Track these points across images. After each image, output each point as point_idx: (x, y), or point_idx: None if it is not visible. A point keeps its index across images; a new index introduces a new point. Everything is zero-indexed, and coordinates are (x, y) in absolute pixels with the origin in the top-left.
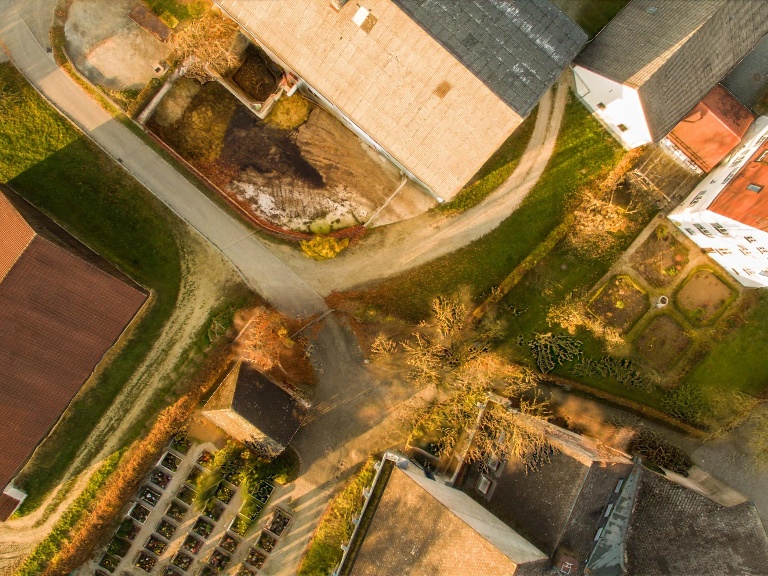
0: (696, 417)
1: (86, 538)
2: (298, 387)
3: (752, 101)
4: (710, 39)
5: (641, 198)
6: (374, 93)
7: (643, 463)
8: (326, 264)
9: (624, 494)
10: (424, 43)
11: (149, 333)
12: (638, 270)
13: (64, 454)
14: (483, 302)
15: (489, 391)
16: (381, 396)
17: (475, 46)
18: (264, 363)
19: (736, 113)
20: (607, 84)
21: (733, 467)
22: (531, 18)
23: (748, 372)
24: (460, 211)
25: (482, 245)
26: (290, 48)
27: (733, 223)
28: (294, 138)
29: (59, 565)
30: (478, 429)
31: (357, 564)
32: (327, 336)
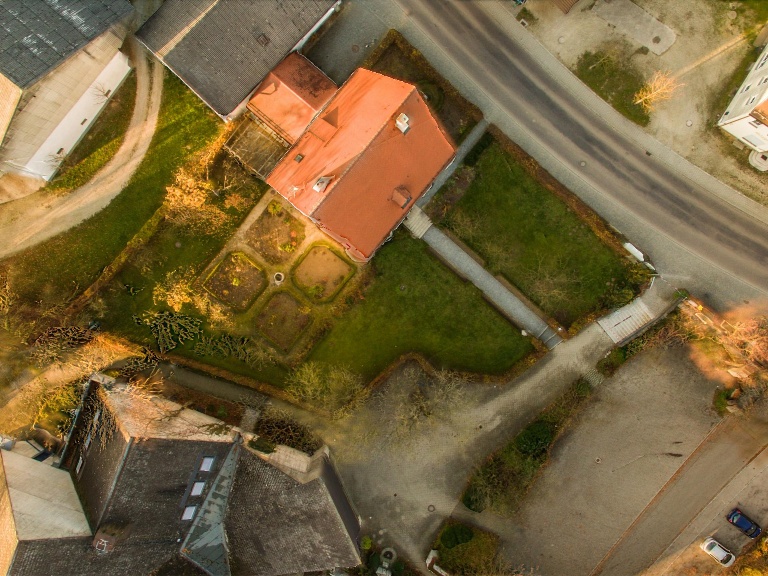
0: (317, 395)
1: None
2: None
3: None
4: (249, 8)
5: (236, 173)
6: None
7: (250, 442)
8: None
9: (224, 473)
10: None
11: None
12: (254, 247)
13: None
14: (95, 281)
15: (100, 371)
16: (5, 378)
17: None
18: None
19: (315, 84)
20: None
21: (366, 446)
22: None
23: (372, 349)
24: (70, 190)
25: (95, 224)
26: None
27: None
28: None
29: None
30: (83, 409)
31: None
32: None
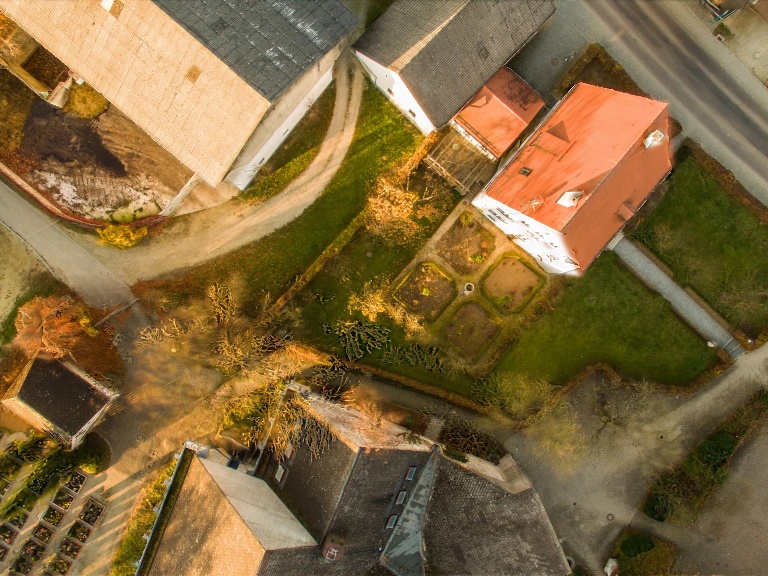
0: (505, 405)
1: None
2: (106, 376)
3: (550, 86)
4: (478, 22)
5: (437, 184)
6: (132, 79)
7: (444, 451)
8: (131, 253)
9: (422, 482)
10: (169, 27)
11: None
12: (444, 257)
13: None
14: (287, 290)
15: (292, 379)
16: (191, 385)
17: (225, 30)
18: (57, 352)
19: (524, 98)
20: (380, 69)
21: (548, 455)
22: (295, 2)
23: (558, 359)
24: (263, 199)
25: (286, 233)
26: (49, 34)
27: (505, 207)
28: (95, 127)
29: None
30: (279, 417)
31: (158, 553)
32: (134, 325)
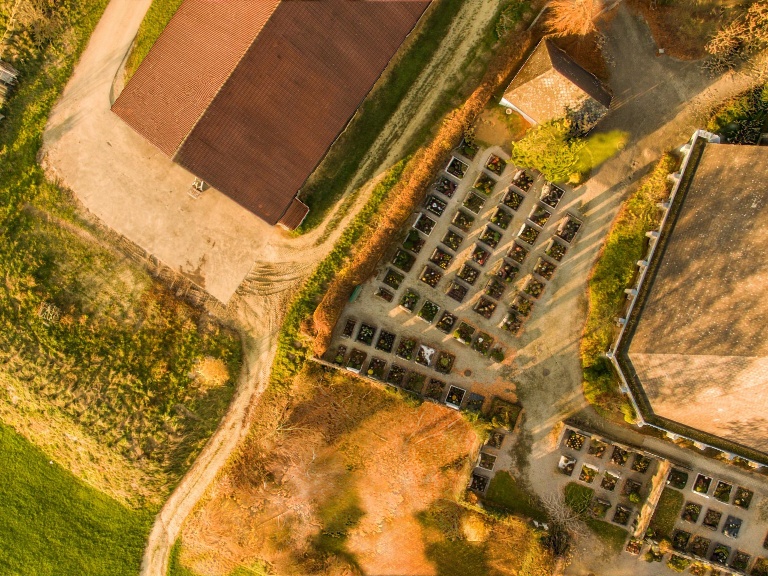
0: None
1: (378, 244)
2: None
3: None
4: None
5: None
6: None
7: None
8: None
9: None
10: None
11: (437, 29)
12: None
13: (347, 165)
14: None
15: None
16: (674, 89)
17: None
18: (575, 32)
19: None
20: None
21: None
22: None
23: None
24: None
25: None
26: None
27: None
28: None
29: (349, 275)
30: None
31: (671, 248)
32: (619, 26)
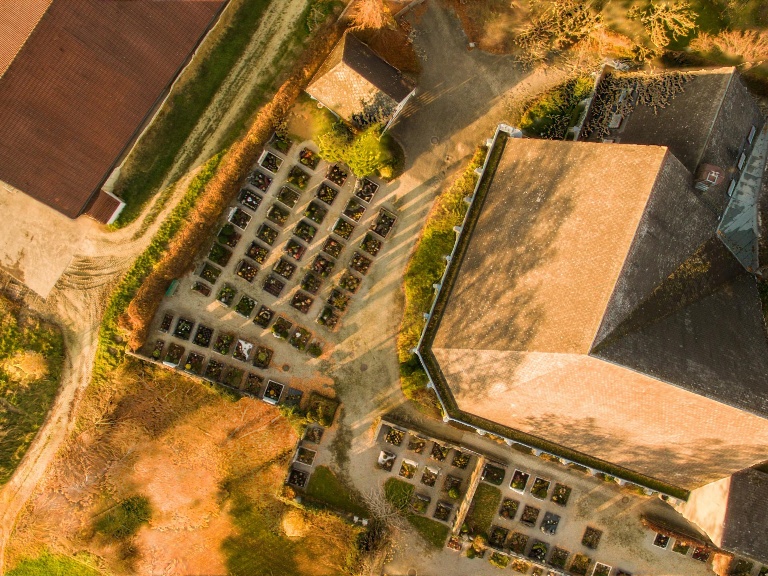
0: None
1: (188, 238)
2: None
3: None
4: None
5: None
6: None
7: None
8: None
9: (755, 153)
10: None
11: (247, 23)
12: None
13: (162, 159)
14: None
15: None
16: (487, 84)
17: None
18: (372, 26)
19: None
20: None
21: None
22: None
23: None
24: None
25: None
26: None
27: None
28: None
29: (161, 269)
30: (595, 97)
31: (472, 243)
32: (430, 20)
